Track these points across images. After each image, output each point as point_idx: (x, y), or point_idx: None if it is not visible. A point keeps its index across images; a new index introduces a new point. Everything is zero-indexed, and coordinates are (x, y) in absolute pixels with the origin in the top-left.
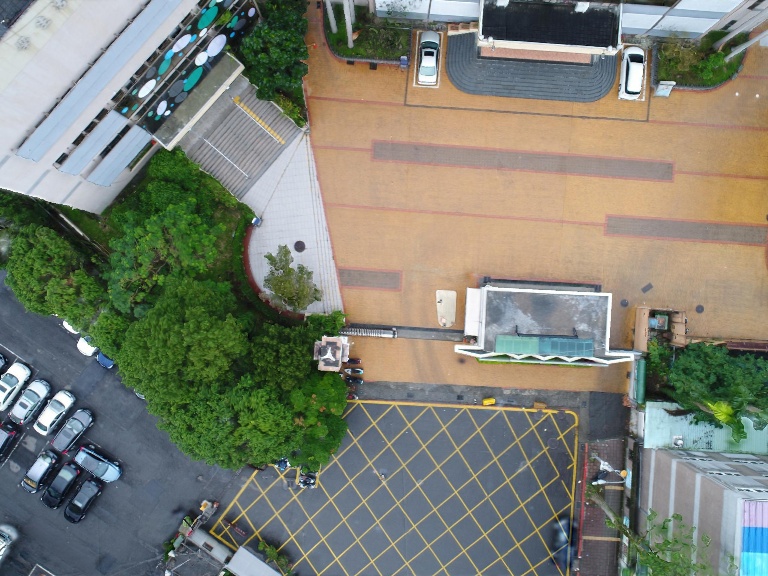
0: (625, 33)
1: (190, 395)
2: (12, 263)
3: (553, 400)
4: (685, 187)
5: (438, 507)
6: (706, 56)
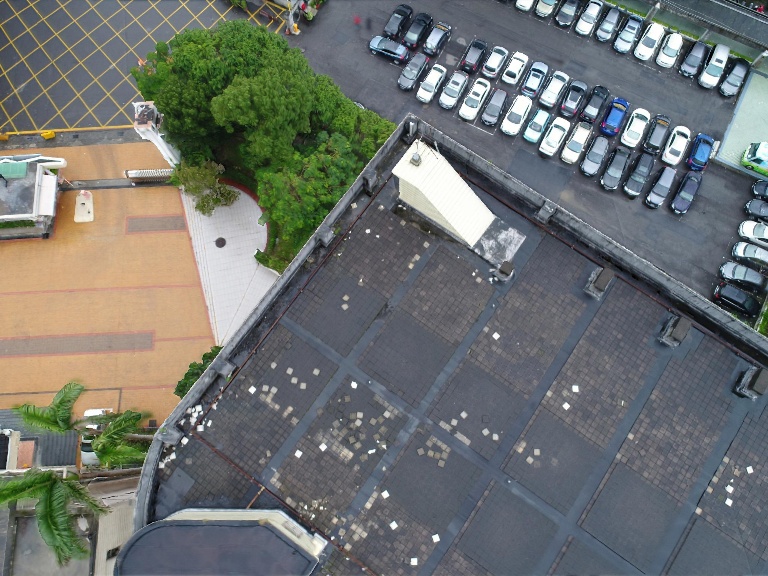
0: None
1: None
2: None
3: None
4: None
5: (97, 50)
6: None
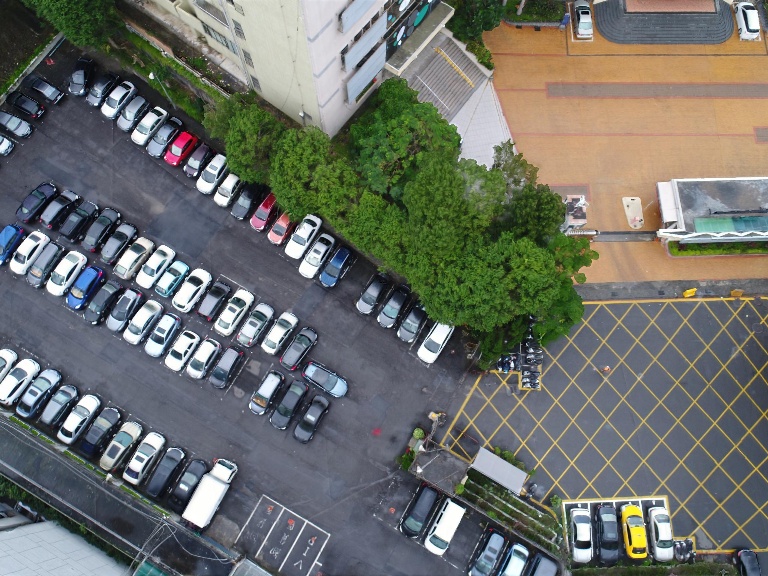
0: None
1: (456, 252)
2: (281, 157)
3: (747, 288)
4: None
5: (663, 399)
6: None
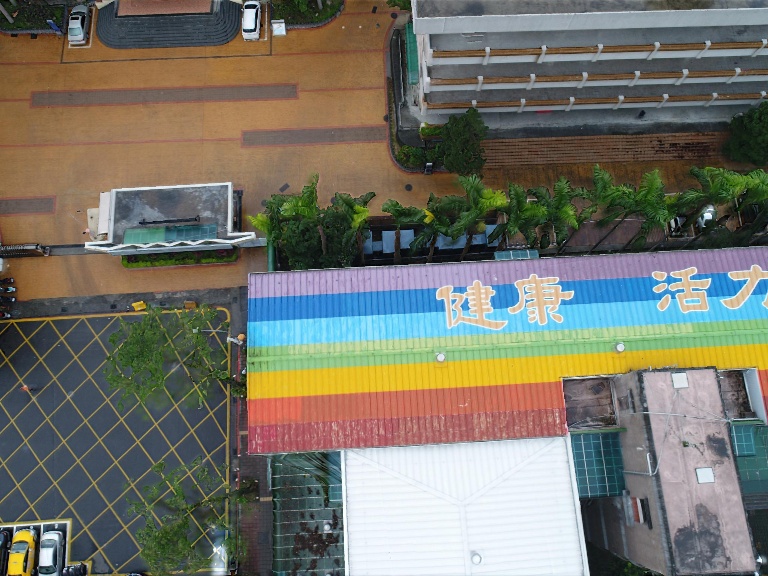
0: None
1: None
2: None
3: (204, 299)
4: (309, 102)
5: (89, 418)
6: None
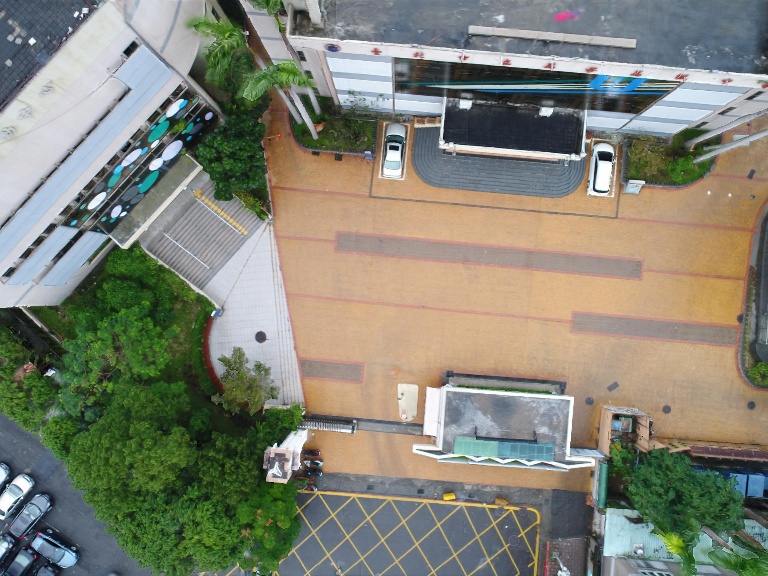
0: (595, 130)
1: (137, 504)
2: None
3: (515, 497)
4: (654, 285)
5: None
6: (677, 155)
